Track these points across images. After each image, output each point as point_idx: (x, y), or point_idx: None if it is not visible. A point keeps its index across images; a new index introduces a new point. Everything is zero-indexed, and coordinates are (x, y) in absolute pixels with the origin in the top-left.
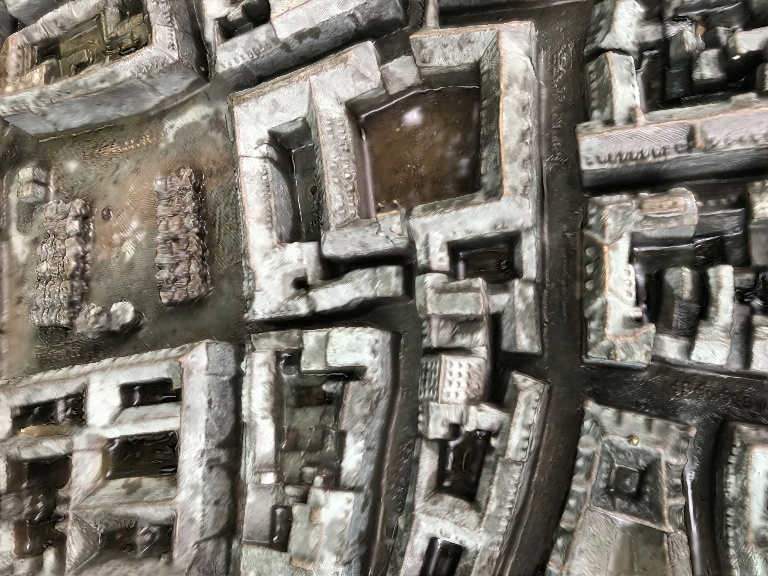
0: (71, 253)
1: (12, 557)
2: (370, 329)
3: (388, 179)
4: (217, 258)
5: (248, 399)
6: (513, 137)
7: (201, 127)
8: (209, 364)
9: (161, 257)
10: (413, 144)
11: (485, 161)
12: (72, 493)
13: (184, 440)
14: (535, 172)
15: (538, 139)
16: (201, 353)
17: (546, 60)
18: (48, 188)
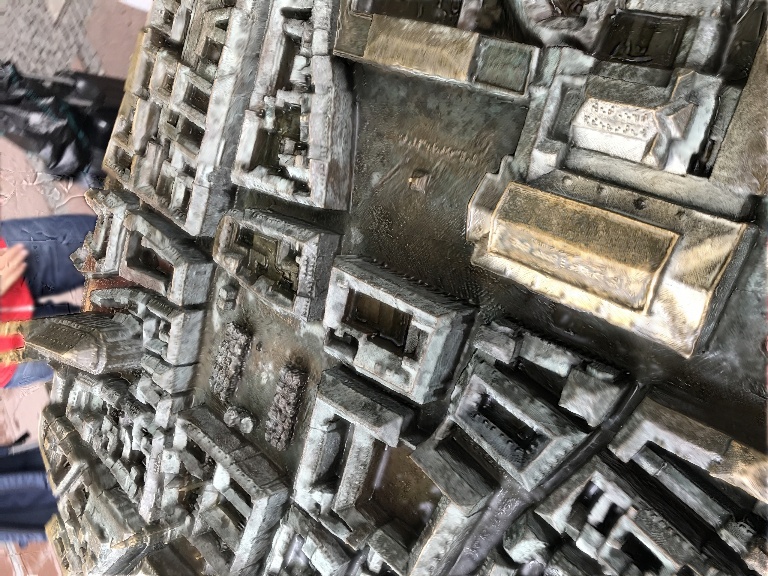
0: (234, 364)
1: (176, 502)
2: (334, 563)
3: (391, 477)
4: (301, 429)
5: (275, 542)
6: (430, 555)
7: (318, 343)
8: (268, 505)
9: (271, 415)
10: (410, 473)
11: (415, 548)
12: (201, 507)
13: (246, 532)
14: (444, 564)
15: (465, 539)
16: (264, 501)
17: (500, 497)
18: (235, 300)
